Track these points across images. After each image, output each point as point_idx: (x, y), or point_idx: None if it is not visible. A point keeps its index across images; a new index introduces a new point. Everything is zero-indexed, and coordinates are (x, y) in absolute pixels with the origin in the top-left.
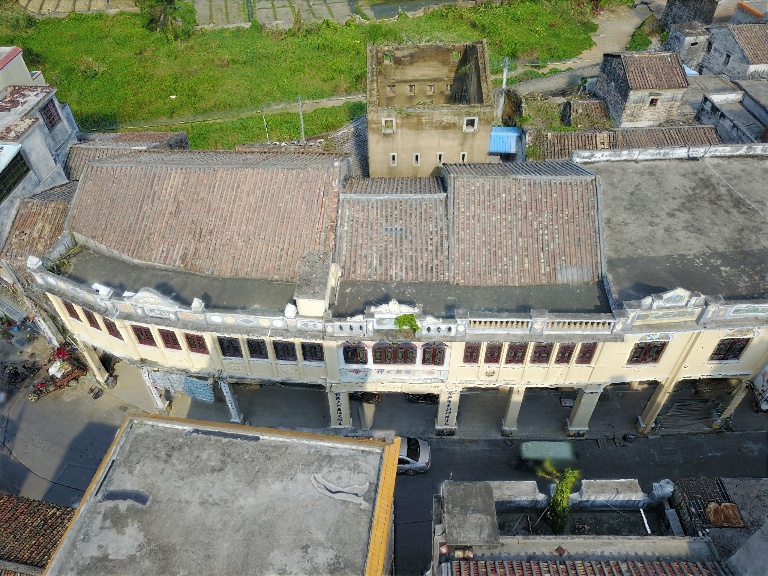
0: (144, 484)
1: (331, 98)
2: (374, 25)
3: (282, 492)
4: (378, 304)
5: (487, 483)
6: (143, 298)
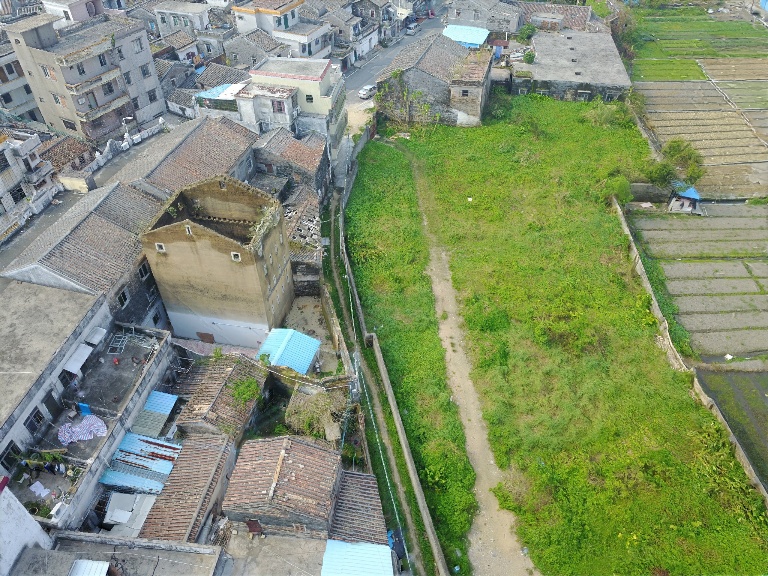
0: None
1: (454, 288)
2: (584, 316)
3: None
4: (62, 205)
5: None
6: (115, 144)
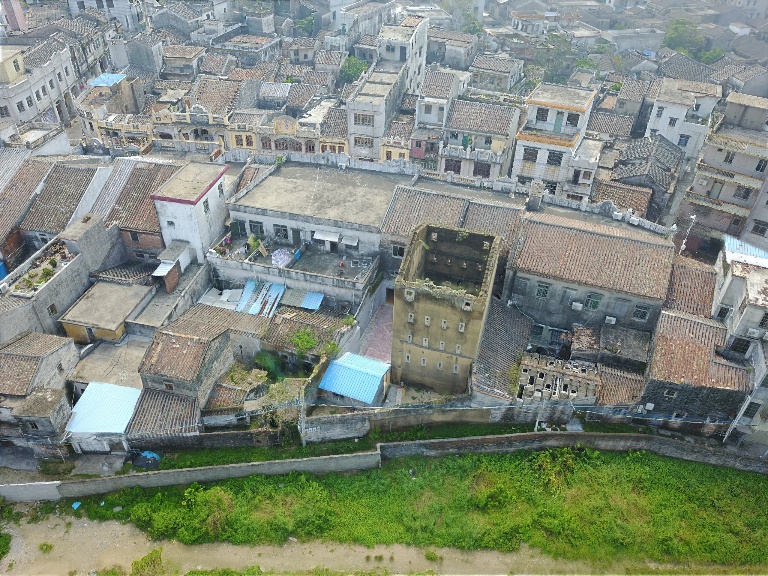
0: (577, 104)
1: None
2: None
3: (549, 100)
4: None
5: (493, 139)
6: None
